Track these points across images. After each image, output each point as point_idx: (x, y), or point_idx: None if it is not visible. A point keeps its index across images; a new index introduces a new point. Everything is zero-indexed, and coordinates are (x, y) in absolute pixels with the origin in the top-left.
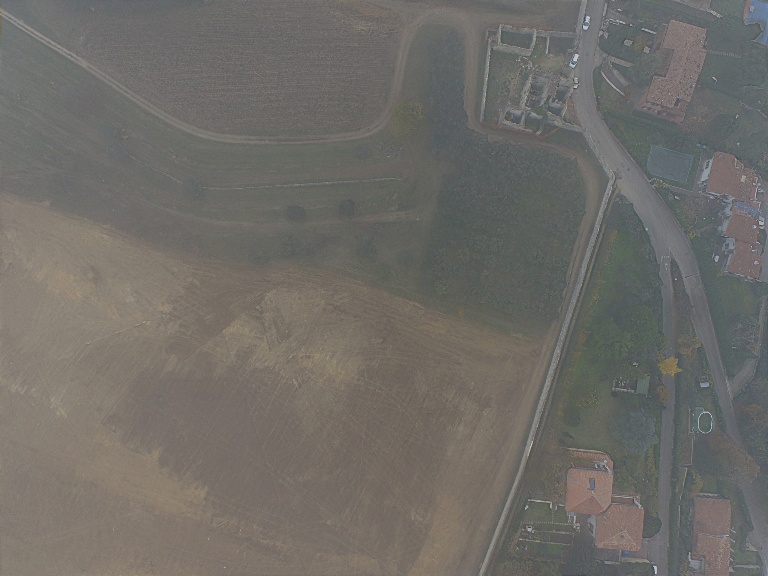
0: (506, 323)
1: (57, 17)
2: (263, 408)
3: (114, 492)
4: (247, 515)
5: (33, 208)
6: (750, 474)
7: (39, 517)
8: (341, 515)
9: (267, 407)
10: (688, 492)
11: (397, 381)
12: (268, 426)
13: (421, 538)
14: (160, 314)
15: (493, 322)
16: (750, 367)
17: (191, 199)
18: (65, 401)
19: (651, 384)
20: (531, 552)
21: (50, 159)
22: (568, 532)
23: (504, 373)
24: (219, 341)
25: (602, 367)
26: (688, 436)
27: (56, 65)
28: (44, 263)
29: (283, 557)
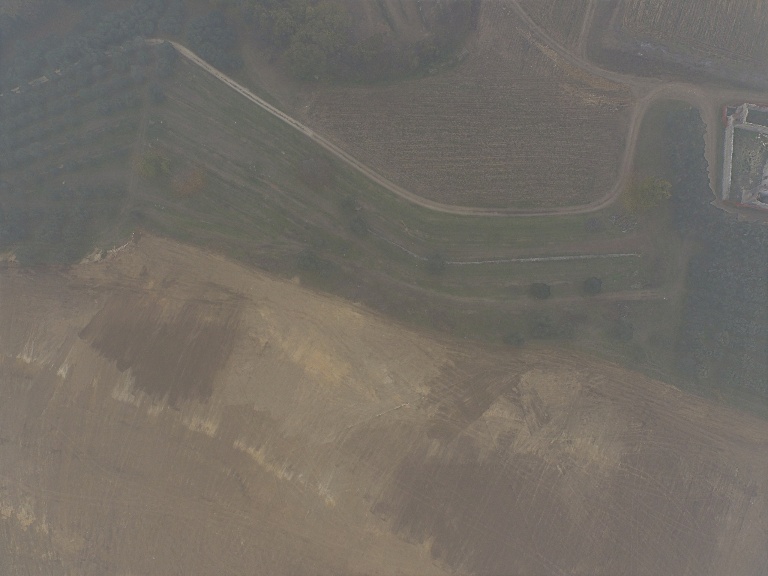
0: (764, 407)
1: (279, 84)
2: (529, 495)
3: None
4: None
5: (284, 285)
6: None
7: None
8: None
9: (533, 494)
10: None
11: (661, 468)
12: (536, 514)
13: None
14: (419, 396)
15: (751, 406)
16: None
17: (429, 273)
18: (333, 488)
19: None
20: None
21: (292, 233)
22: None
23: (767, 460)
24: (480, 425)
25: None
26: None
27: (284, 134)
28: (299, 342)
29: None
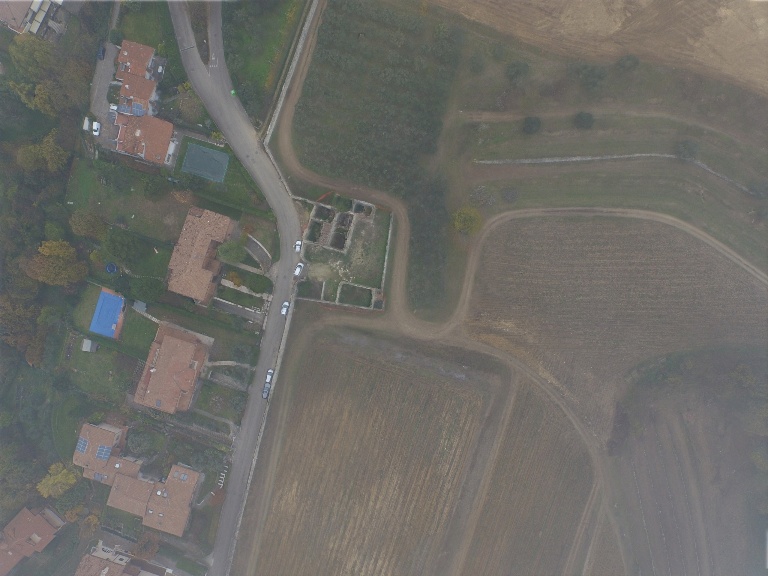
0: None
1: None
2: None
3: None
4: None
5: None
6: None
7: None
8: None
9: None
10: None
11: None
12: None
13: None
14: (729, 6)
15: None
16: None
17: None
18: None
19: None
20: None
21: None
22: None
23: None
24: None
25: None
26: None
27: None
28: None
29: None
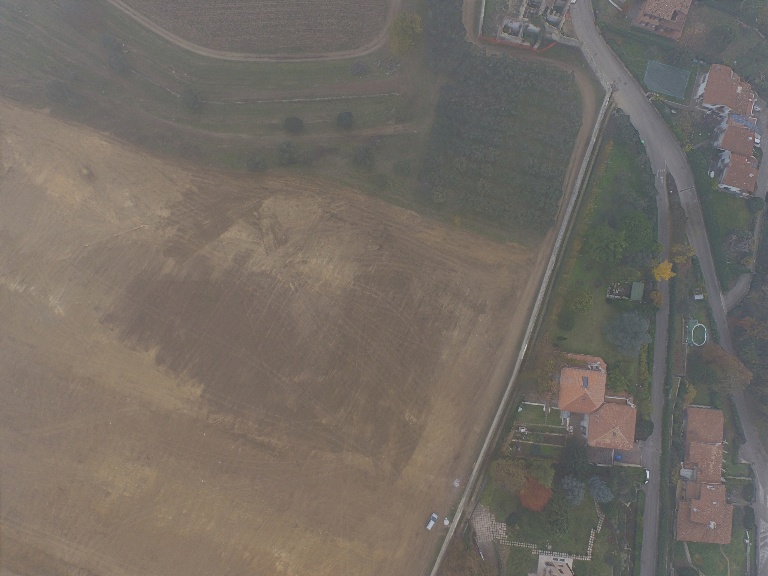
0: (502, 232)
1: None
2: (260, 310)
3: (111, 388)
4: (243, 412)
5: (33, 114)
6: (743, 381)
7: (37, 410)
8: (336, 414)
9: (264, 309)
10: (681, 400)
11: (393, 287)
12: (264, 328)
13: (415, 438)
14: (158, 218)
15: (489, 231)
16: (744, 283)
17: (190, 112)
18: (63, 300)
19: (645, 291)
20: (524, 452)
21: (51, 70)
22: (561, 434)
23: (499, 280)
24: (217, 245)
25: (597, 275)
26: (682, 347)
27: None
28: (44, 167)
29: (278, 453)
